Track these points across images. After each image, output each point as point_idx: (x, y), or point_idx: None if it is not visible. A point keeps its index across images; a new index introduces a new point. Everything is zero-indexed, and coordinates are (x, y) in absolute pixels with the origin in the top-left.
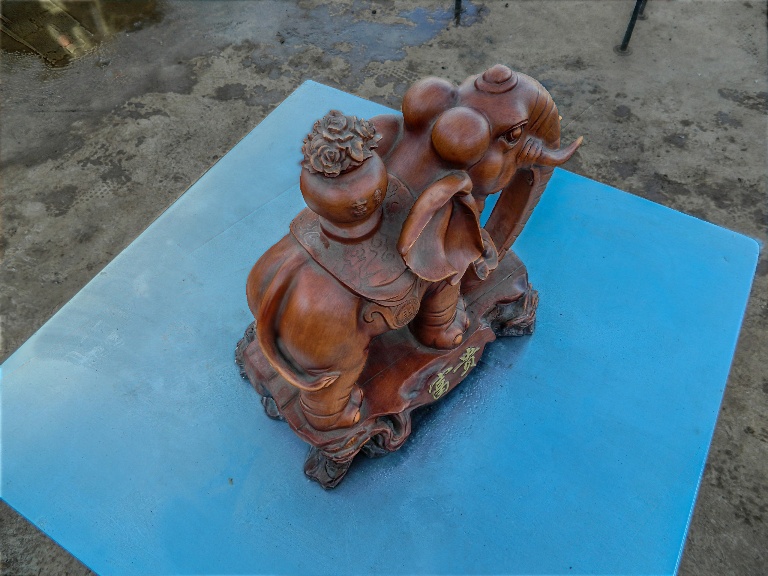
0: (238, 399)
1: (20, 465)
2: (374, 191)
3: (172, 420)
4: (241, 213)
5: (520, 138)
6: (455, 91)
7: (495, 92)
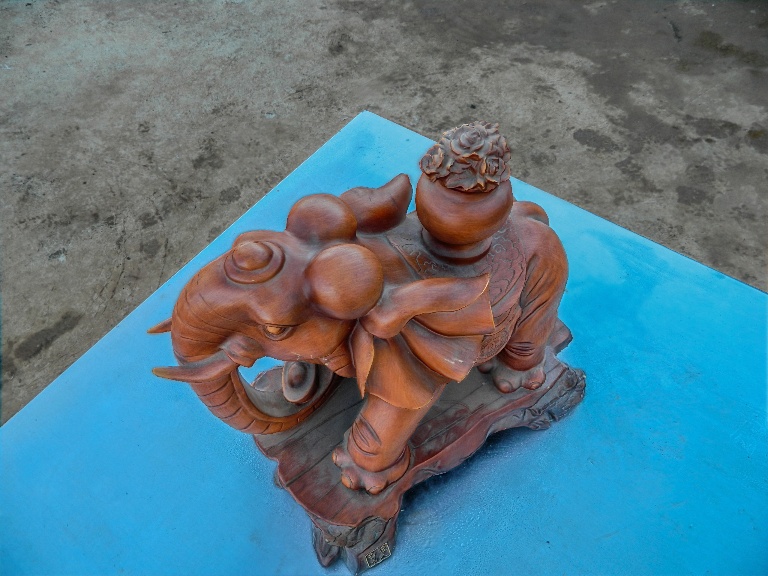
0: (575, 357)
1: None
2: None
3: (637, 344)
4: None
5: None
6: None
7: None
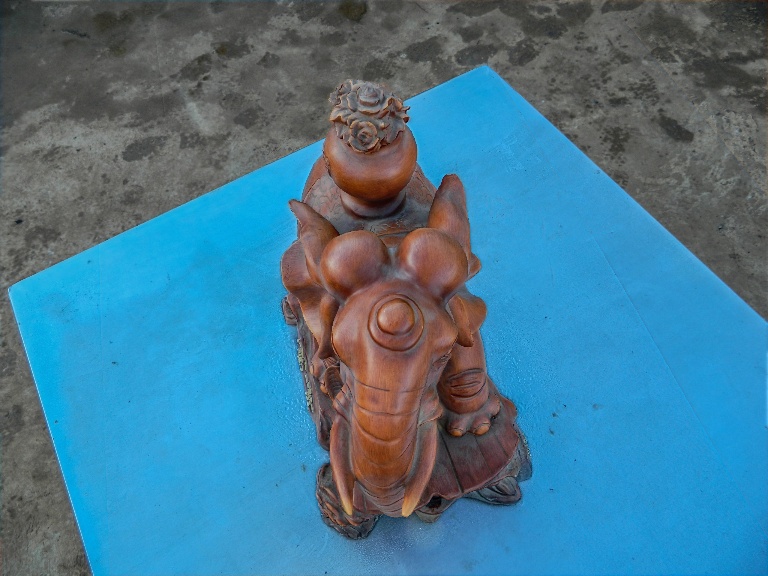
0: None
1: (434, 105)
2: (327, 156)
3: None
4: (639, 299)
5: (346, 365)
6: (415, 277)
7: (375, 306)
